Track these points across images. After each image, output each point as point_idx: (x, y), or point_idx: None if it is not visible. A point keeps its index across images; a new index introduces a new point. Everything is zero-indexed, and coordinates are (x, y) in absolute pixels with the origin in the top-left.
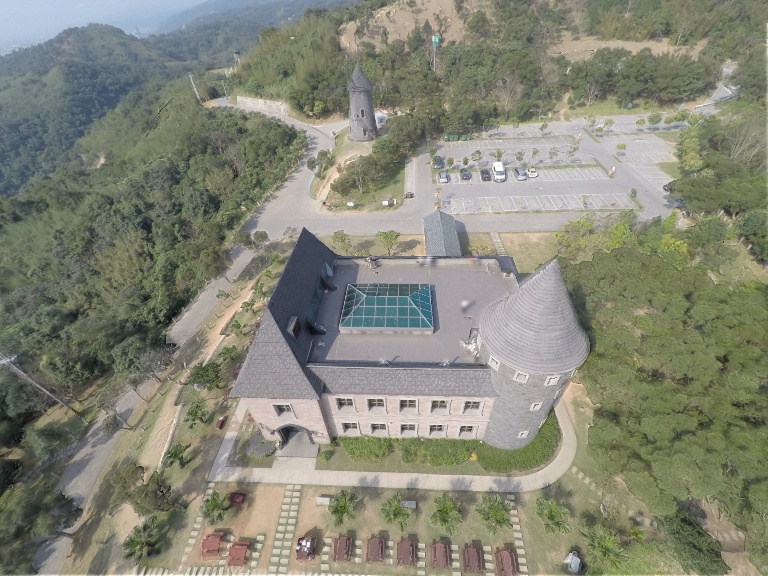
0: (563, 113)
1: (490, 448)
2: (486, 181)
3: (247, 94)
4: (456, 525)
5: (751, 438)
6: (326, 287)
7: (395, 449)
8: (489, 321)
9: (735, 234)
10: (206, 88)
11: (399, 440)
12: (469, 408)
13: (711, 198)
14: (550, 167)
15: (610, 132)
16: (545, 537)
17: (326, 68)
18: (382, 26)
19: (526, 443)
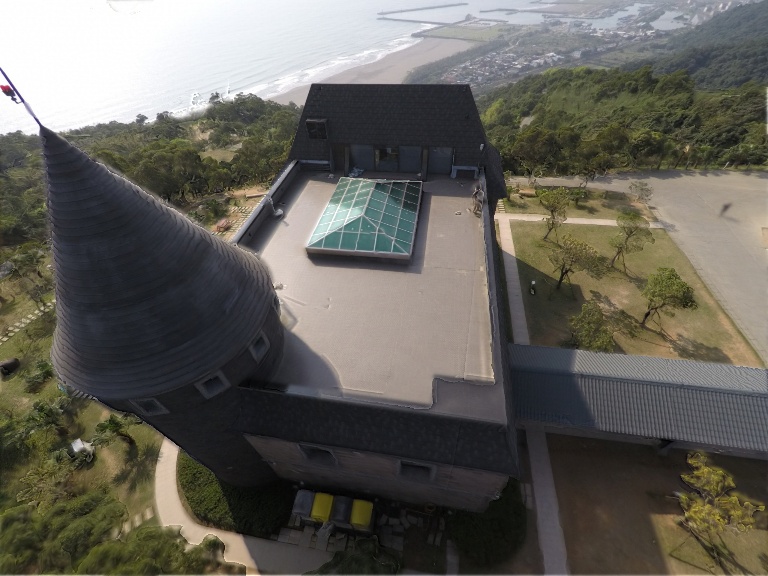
0: None
1: None
2: None
3: None
4: None
5: None
6: None
7: None
8: None
9: None
10: None
11: None
12: None
13: None
14: None
15: None
16: None
17: None
18: None
19: None
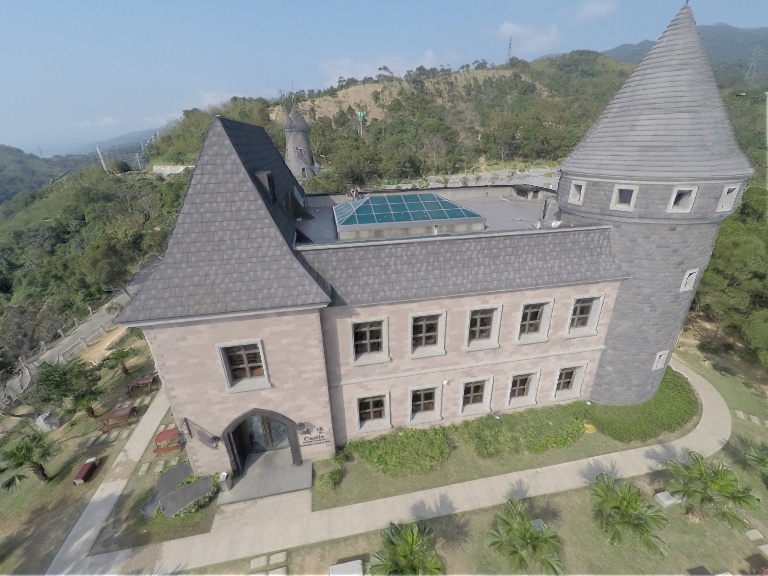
0: (483, 168)
1: (607, 408)
2: None
3: (166, 163)
4: (639, 547)
5: None
6: (299, 214)
7: (457, 443)
8: (589, 151)
9: None
10: (116, 163)
11: (458, 427)
12: (572, 326)
13: None
14: None
15: (529, 175)
16: None
17: None
18: (309, 105)
19: (656, 387)
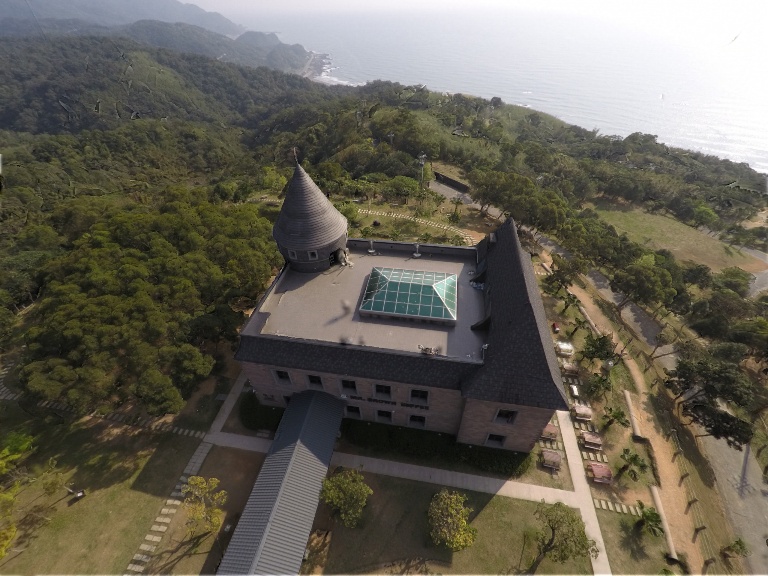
0: None
1: None
2: None
3: None
4: None
5: None
6: None
7: None
8: None
9: None
10: None
11: None
12: None
13: None
14: None
15: None
16: None
17: None
18: None
19: None
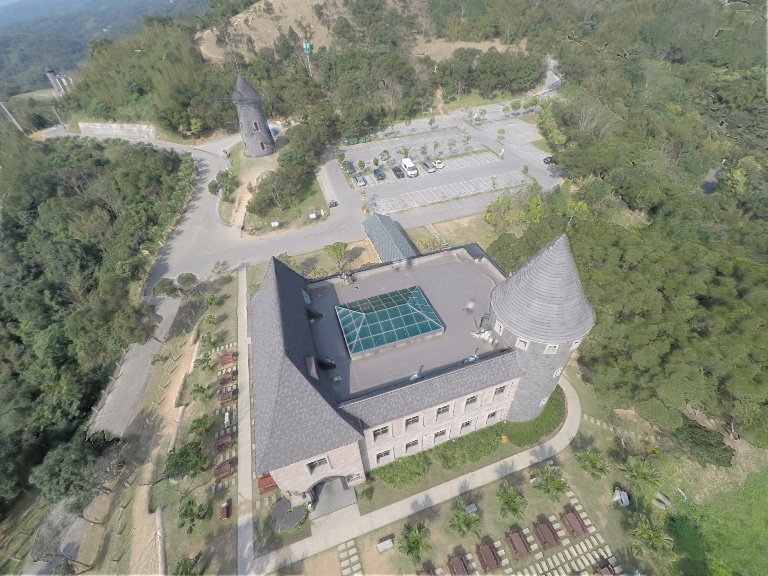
0: (441, 108)
1: (515, 425)
2: (401, 178)
3: (93, 119)
4: None
5: (709, 344)
6: (311, 316)
7: (432, 460)
8: (506, 306)
9: (611, 189)
10: (29, 117)
11: (432, 450)
12: (495, 394)
13: (585, 164)
14: (450, 157)
15: (485, 120)
16: (591, 486)
17: (193, 82)
18: (245, 34)
19: (543, 408)
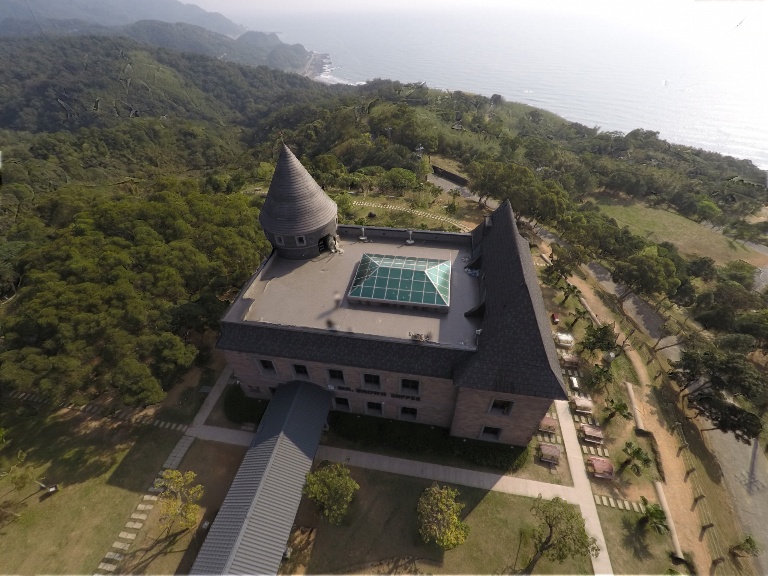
0: None
1: None
2: None
3: None
4: None
5: None
6: None
7: None
8: None
9: None
10: None
11: None
12: None
13: None
14: None
15: None
16: None
17: None
18: None
19: None
